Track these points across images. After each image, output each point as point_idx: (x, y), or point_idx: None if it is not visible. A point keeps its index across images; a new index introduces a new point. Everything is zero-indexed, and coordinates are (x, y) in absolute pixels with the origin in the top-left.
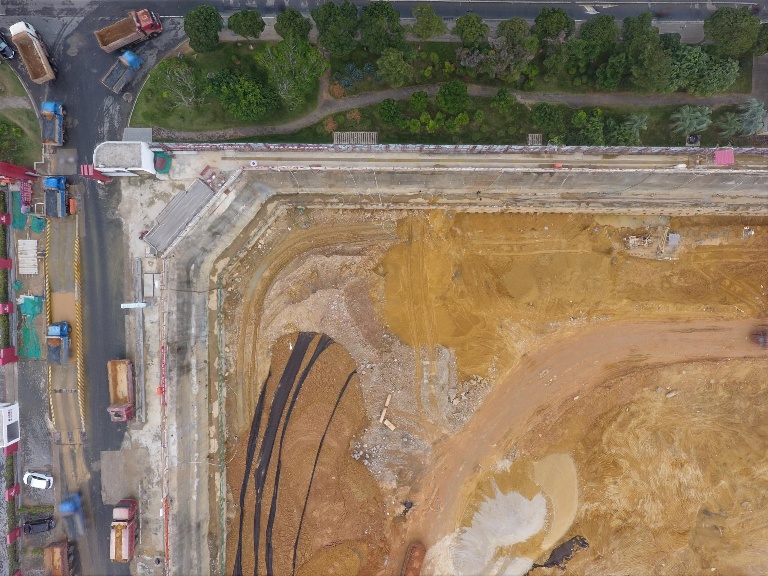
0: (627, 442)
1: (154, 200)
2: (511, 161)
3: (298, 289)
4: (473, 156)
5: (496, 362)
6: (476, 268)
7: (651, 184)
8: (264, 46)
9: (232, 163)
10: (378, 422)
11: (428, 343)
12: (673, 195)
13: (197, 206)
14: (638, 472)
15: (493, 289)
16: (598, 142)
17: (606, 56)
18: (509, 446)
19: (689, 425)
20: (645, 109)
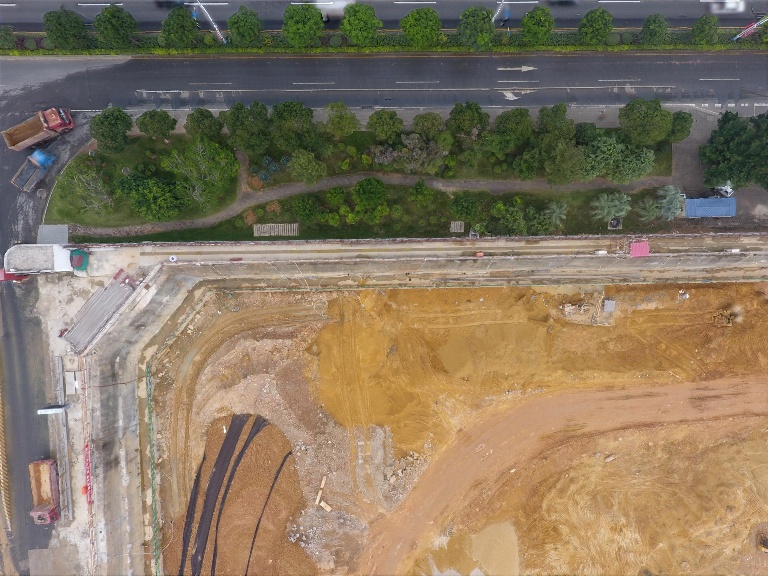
0: (567, 508)
1: (73, 297)
2: (434, 249)
3: (229, 373)
4: (395, 245)
5: (432, 438)
6: (412, 342)
7: (576, 266)
8: (179, 139)
9: (151, 258)
10: (314, 503)
11: (362, 423)
12: (602, 271)
13: (116, 303)
14: (578, 538)
15: (428, 364)
16: (520, 228)
17: (522, 148)
18: (446, 522)
19: (629, 487)
20: (566, 194)
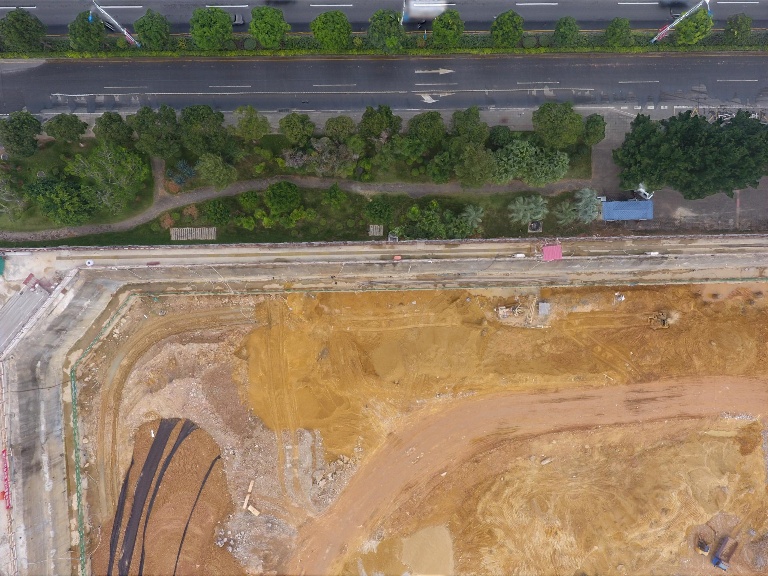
0: (502, 511)
1: None
2: (353, 253)
3: (156, 377)
4: (314, 249)
5: (362, 442)
6: (343, 346)
7: (498, 269)
8: (95, 143)
9: (67, 262)
10: (242, 508)
11: (290, 427)
12: (529, 274)
13: None
14: (513, 541)
15: (358, 368)
16: (439, 231)
17: (435, 151)
18: (376, 526)
19: (566, 490)
20: (486, 197)
